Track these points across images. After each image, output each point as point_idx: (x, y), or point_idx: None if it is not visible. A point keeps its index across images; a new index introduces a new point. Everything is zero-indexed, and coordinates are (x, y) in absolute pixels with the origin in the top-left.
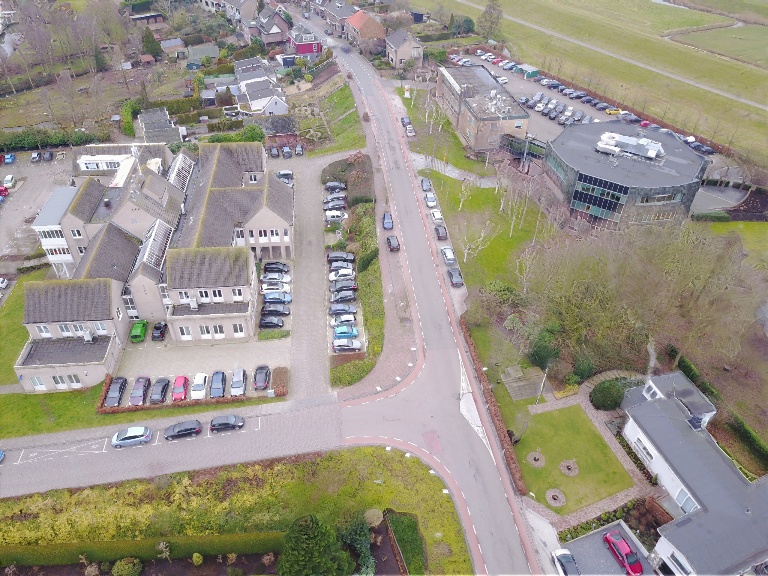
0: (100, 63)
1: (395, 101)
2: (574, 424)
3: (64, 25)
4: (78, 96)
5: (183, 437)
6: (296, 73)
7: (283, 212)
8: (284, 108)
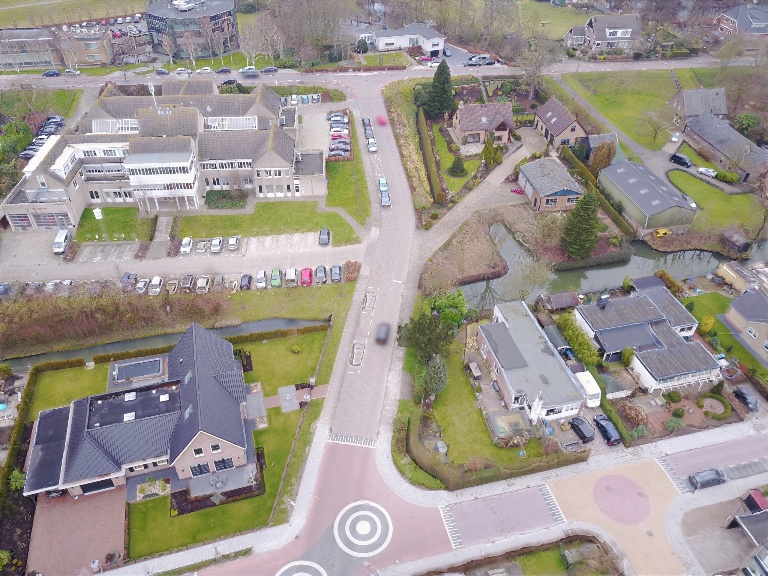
0: None
1: None
2: None
3: None
4: None
5: None
6: None
7: None
8: None
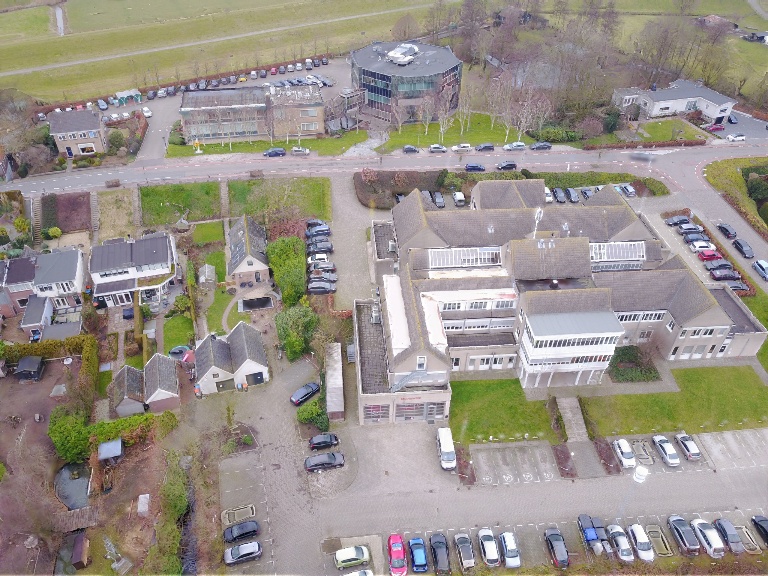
0: None
1: (211, 158)
2: (651, 127)
3: None
4: None
5: None
6: (28, 243)
7: None
8: (174, 244)
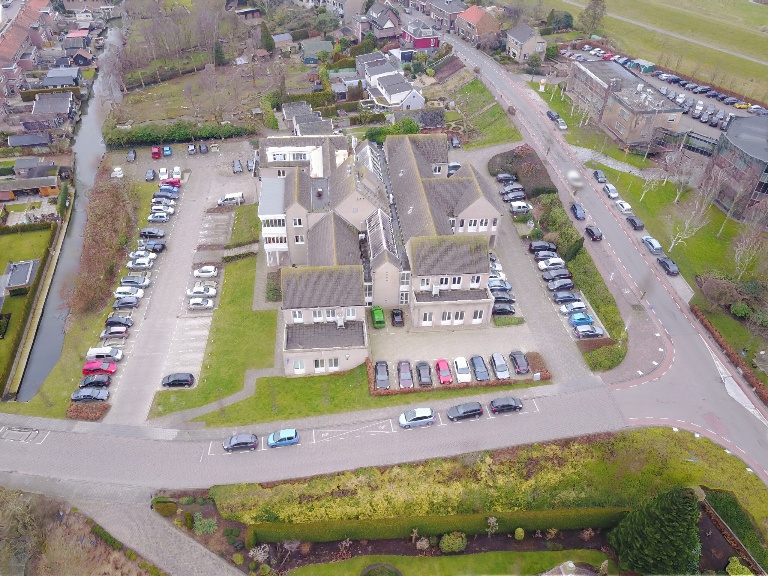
0: (220, 57)
1: (532, 95)
2: None
3: (183, 20)
4: None
5: (467, 418)
6: (417, 67)
7: (493, 202)
8: (421, 102)
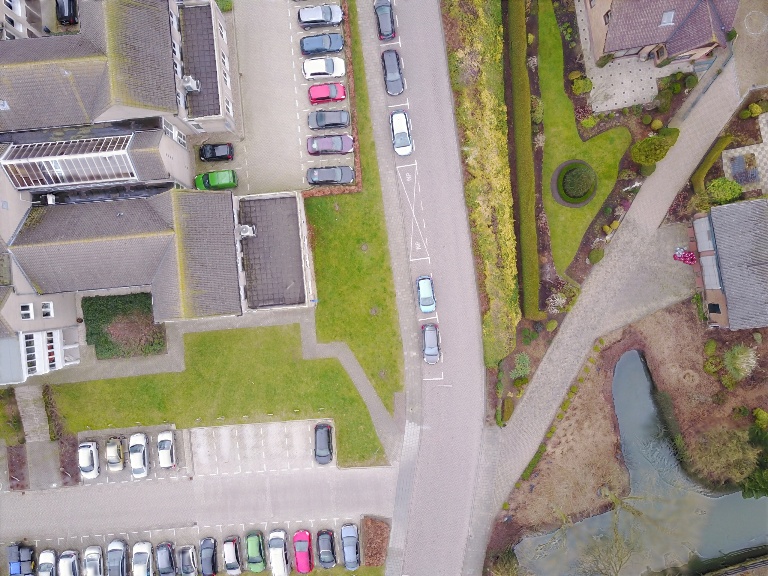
0: None
1: None
2: None
3: None
4: None
5: None
6: None
7: None
8: None
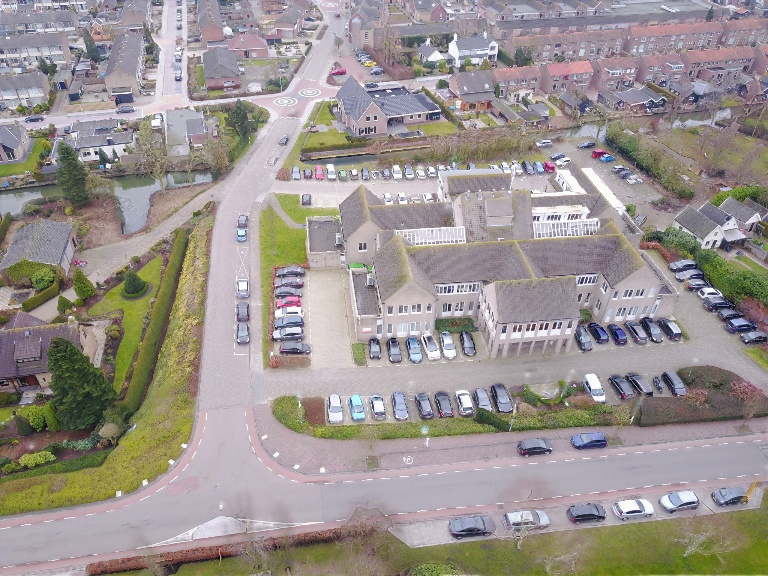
0: None
1: None
2: None
3: None
4: (764, 162)
5: None
6: None
7: (511, 307)
8: None
